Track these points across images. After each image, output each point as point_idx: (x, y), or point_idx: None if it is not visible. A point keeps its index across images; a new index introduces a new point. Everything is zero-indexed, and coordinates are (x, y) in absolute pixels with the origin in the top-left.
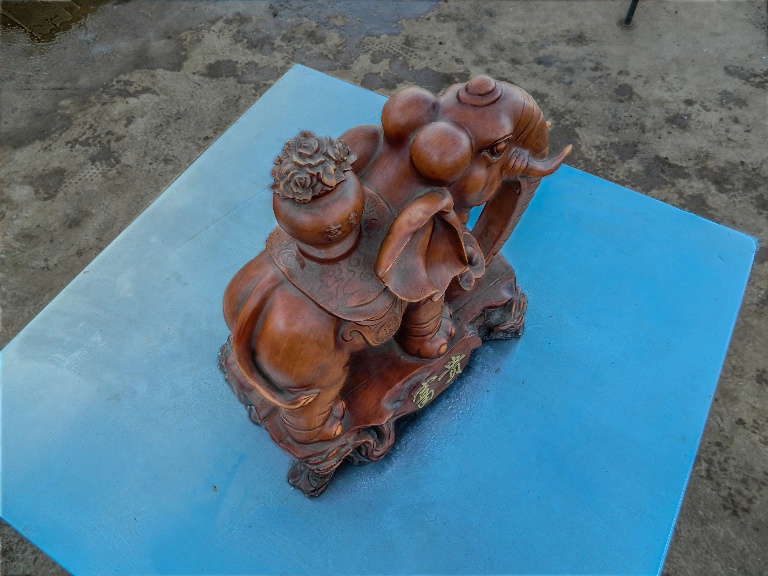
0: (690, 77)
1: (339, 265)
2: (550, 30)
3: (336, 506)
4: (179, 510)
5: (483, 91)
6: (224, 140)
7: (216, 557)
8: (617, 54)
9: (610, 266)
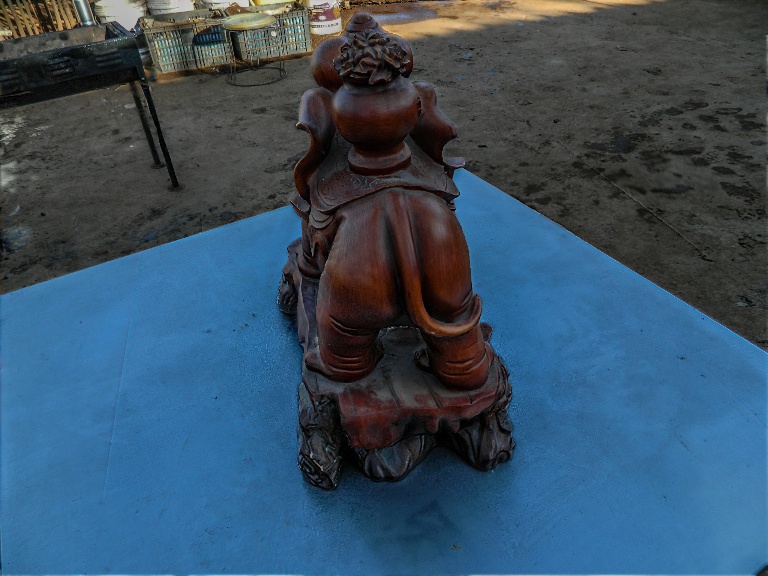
0: (254, 186)
1: (412, 165)
2: (126, 221)
3: (528, 441)
4: None
5: (368, 17)
6: (6, 389)
7: (539, 574)
8: (193, 204)
9: None
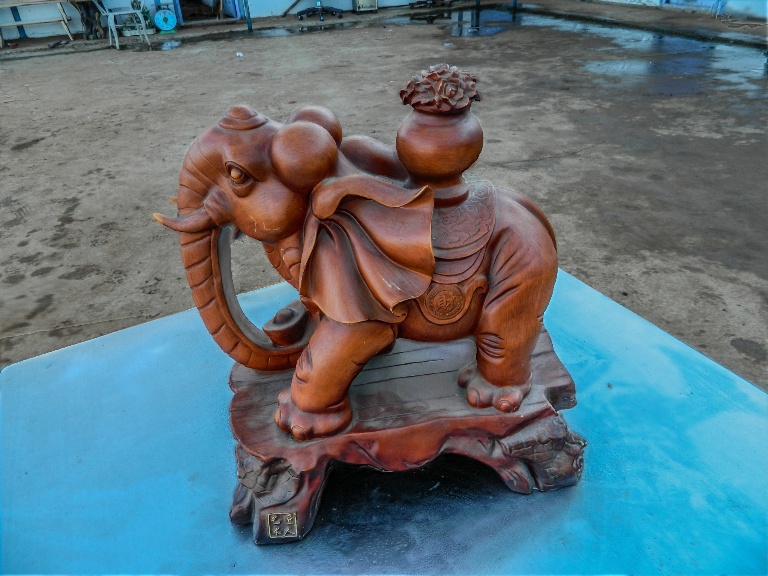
0: None
1: None
2: None
3: None
4: (646, 384)
5: None
6: None
7: (614, 350)
8: None
9: (128, 398)
